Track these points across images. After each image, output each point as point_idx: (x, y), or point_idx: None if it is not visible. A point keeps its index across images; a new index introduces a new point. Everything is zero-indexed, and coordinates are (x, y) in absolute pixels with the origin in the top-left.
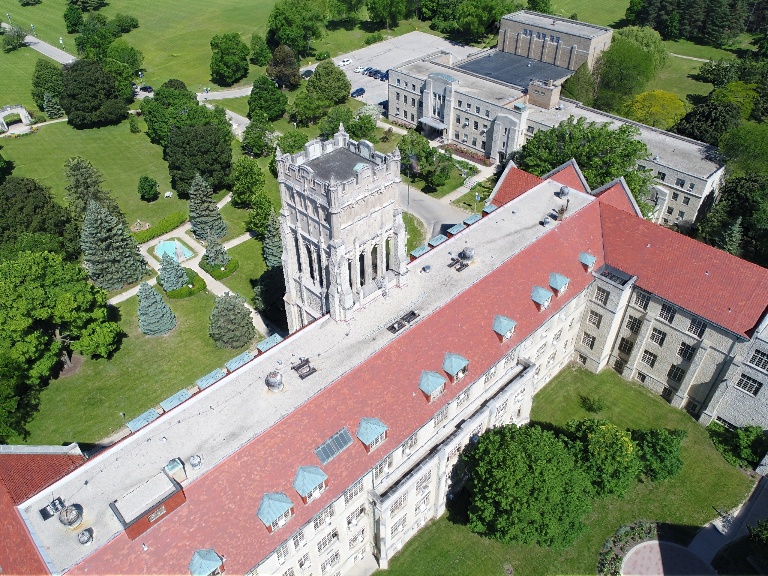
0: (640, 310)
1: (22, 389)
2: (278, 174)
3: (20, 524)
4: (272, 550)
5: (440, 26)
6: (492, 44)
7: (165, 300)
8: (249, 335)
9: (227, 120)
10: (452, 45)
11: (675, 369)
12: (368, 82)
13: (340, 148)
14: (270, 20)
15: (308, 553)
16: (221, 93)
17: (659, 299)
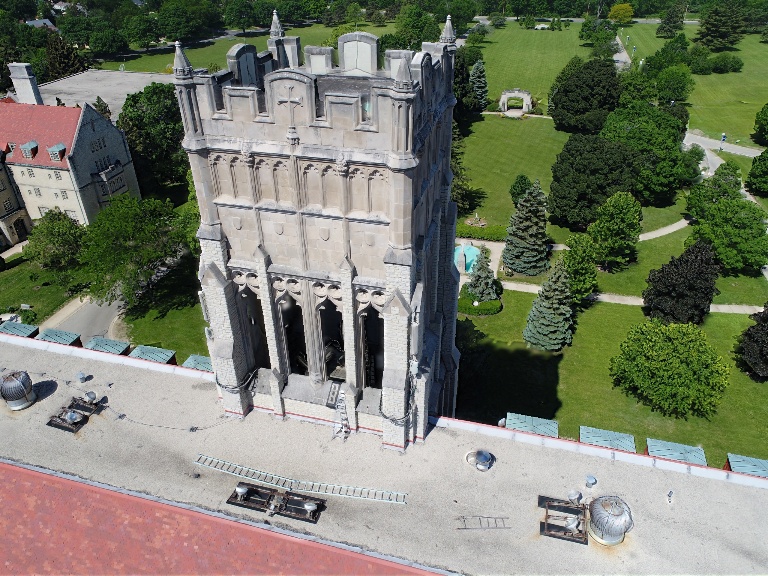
0: None
1: None
2: None
3: None
4: None
5: None
6: None
7: None
8: None
9: (700, 169)
10: None
11: None
12: None
13: None
14: None
15: None
16: (746, 149)
17: None
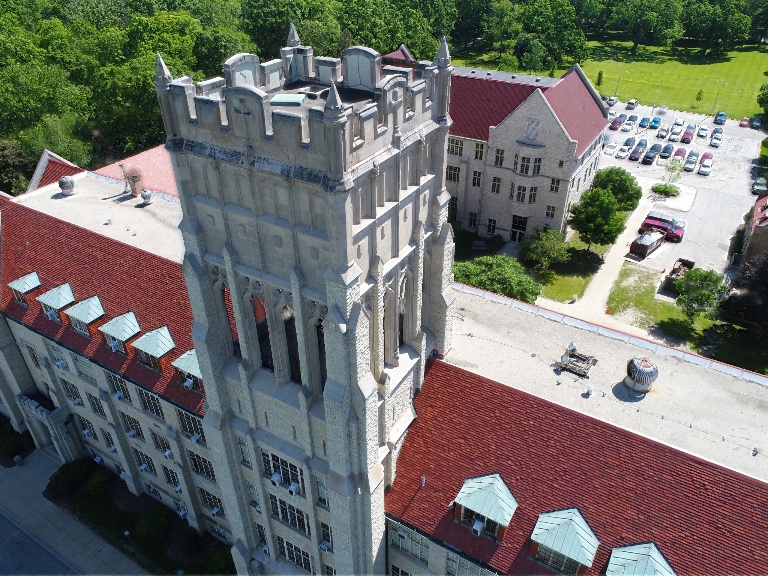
0: None
1: None
2: (343, 169)
3: None
4: None
5: None
6: None
7: None
8: None
9: None
10: None
11: None
12: None
13: None
14: None
15: None
16: None
17: None
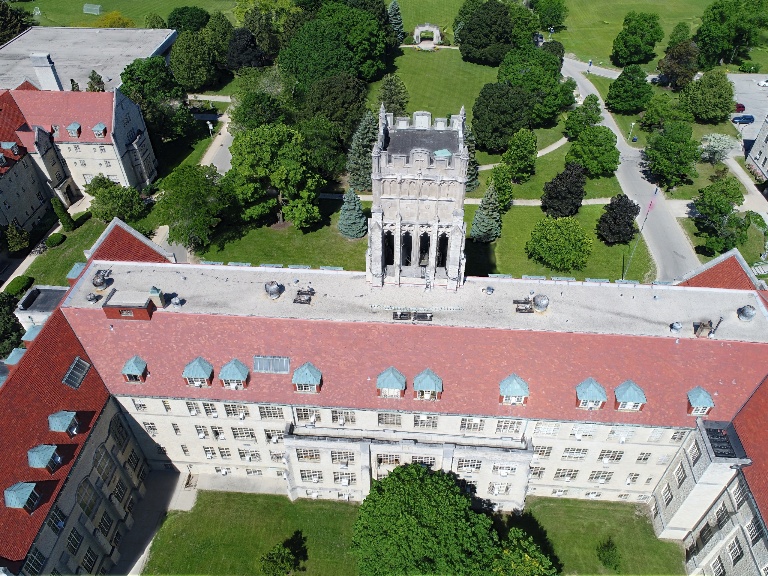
0: (733, 504)
1: (247, 221)
2: None
3: (84, 269)
4: (181, 397)
5: None
6: None
7: None
8: None
9: (574, 95)
10: None
11: None
12: None
13: (455, 131)
14: (707, 11)
15: (222, 428)
16: (607, 71)
17: (754, 506)
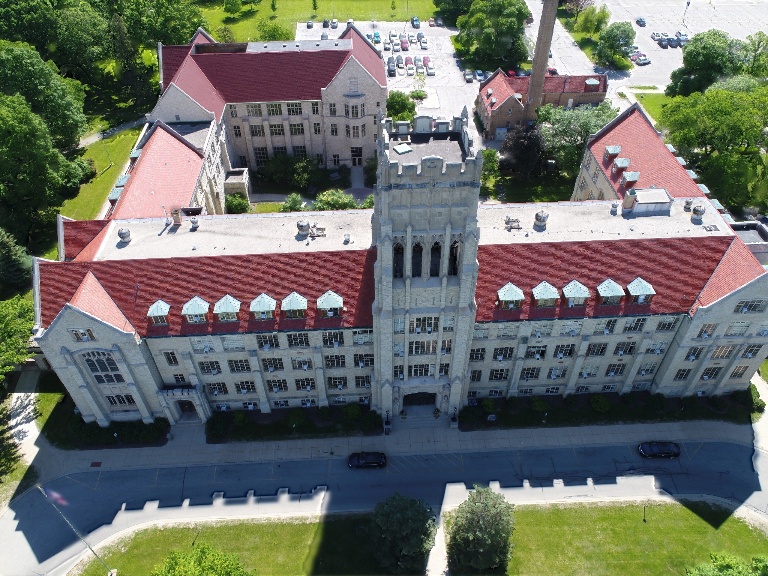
0: None
1: None
2: None
3: None
4: None
5: None
6: None
7: None
8: None
9: None
10: None
11: None
12: None
13: None
14: None
15: None
16: None
17: None
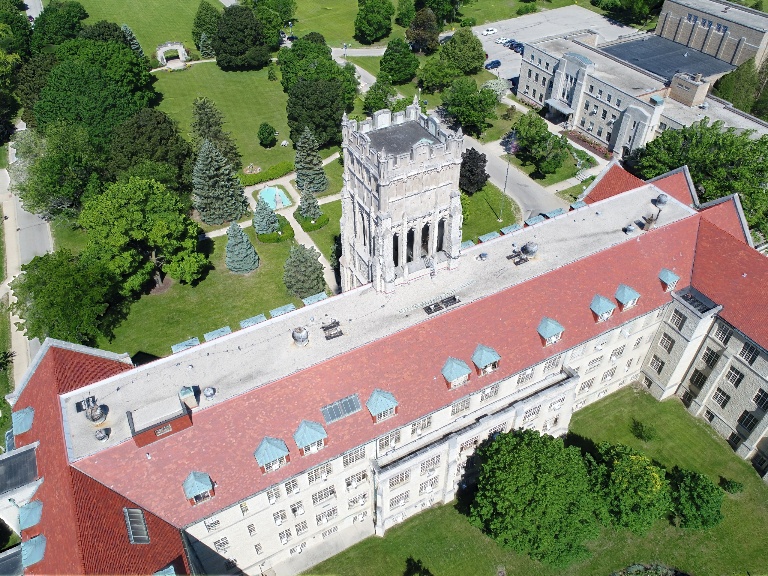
0: (719, 343)
1: (119, 298)
2: None
3: (58, 410)
4: (262, 489)
5: (602, 2)
6: (650, 27)
7: (255, 242)
8: (318, 289)
9: (356, 78)
10: (610, 24)
11: (748, 416)
12: (507, 55)
13: (412, 121)
14: None
15: (302, 501)
16: (360, 50)
17: (742, 336)
